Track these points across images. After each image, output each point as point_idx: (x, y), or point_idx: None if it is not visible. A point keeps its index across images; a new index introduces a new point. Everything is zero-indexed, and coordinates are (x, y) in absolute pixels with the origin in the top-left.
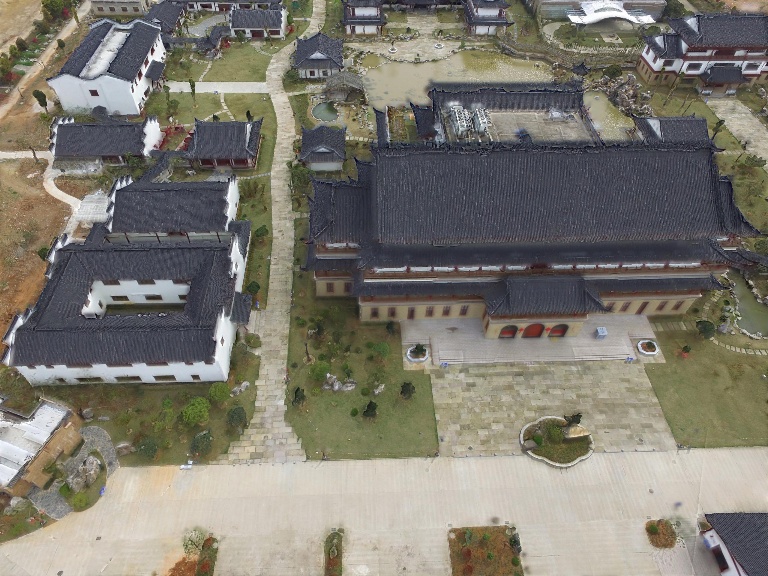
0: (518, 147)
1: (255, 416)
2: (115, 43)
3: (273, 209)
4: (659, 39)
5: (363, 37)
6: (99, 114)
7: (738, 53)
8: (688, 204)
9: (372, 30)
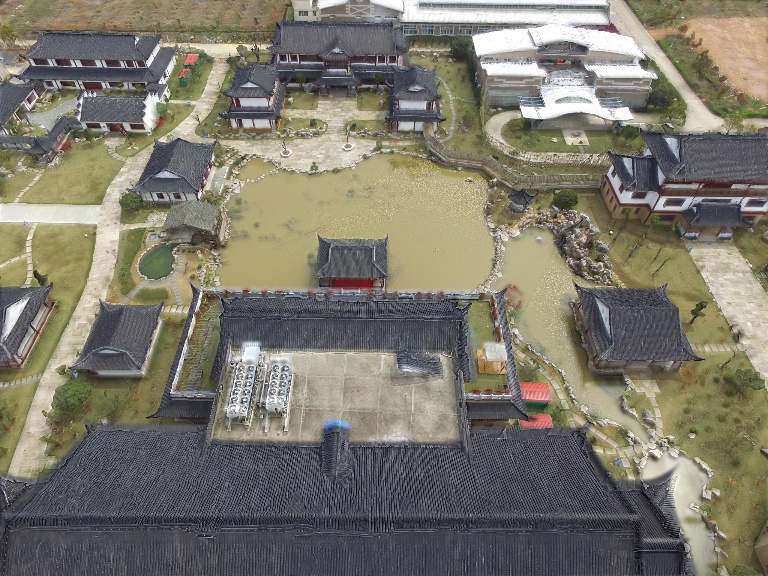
0: (271, 520)
1: None
2: None
3: (17, 449)
4: (627, 161)
5: (252, 133)
6: None
7: (736, 185)
8: None
9: (264, 124)
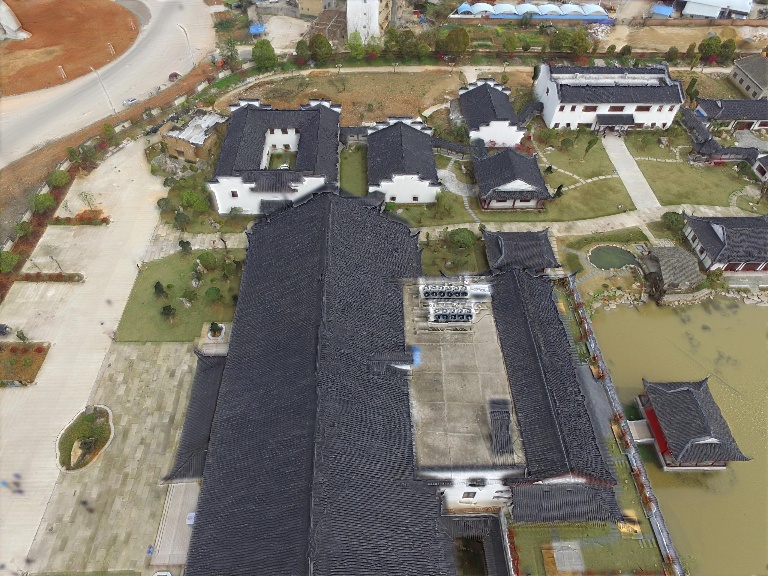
0: None
1: (190, 234)
2: (633, 83)
3: (422, 228)
4: None
5: None
6: (531, 106)
7: None
8: (232, 569)
9: None
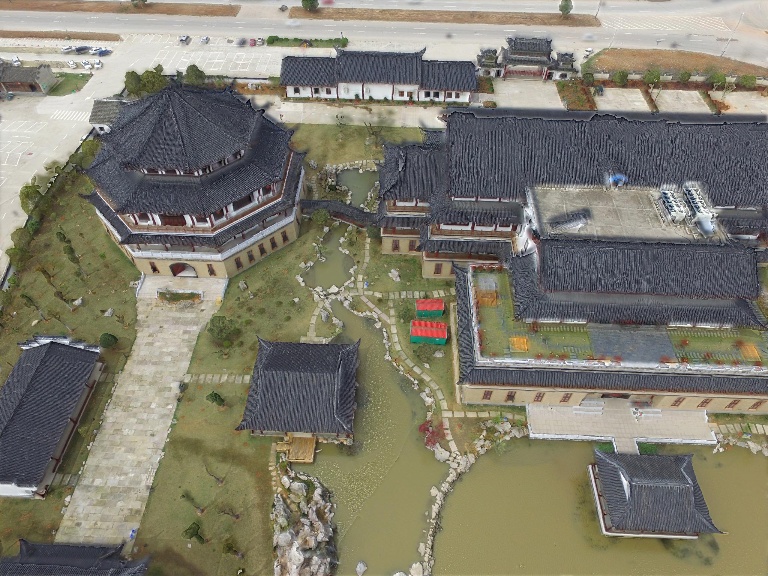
0: None
1: None
2: None
3: None
4: None
5: None
6: None
7: None
8: None
9: None
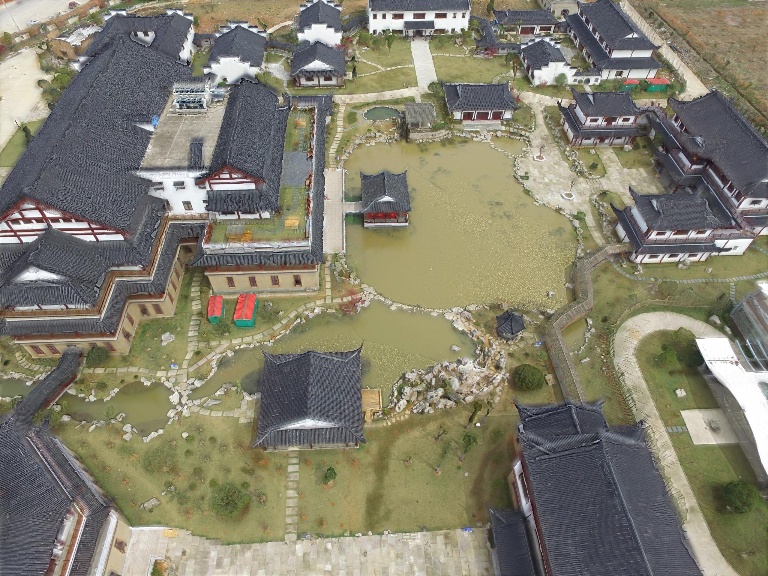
0: None
1: None
2: None
3: None
4: None
5: (559, 134)
6: None
7: None
8: None
9: (571, 135)
